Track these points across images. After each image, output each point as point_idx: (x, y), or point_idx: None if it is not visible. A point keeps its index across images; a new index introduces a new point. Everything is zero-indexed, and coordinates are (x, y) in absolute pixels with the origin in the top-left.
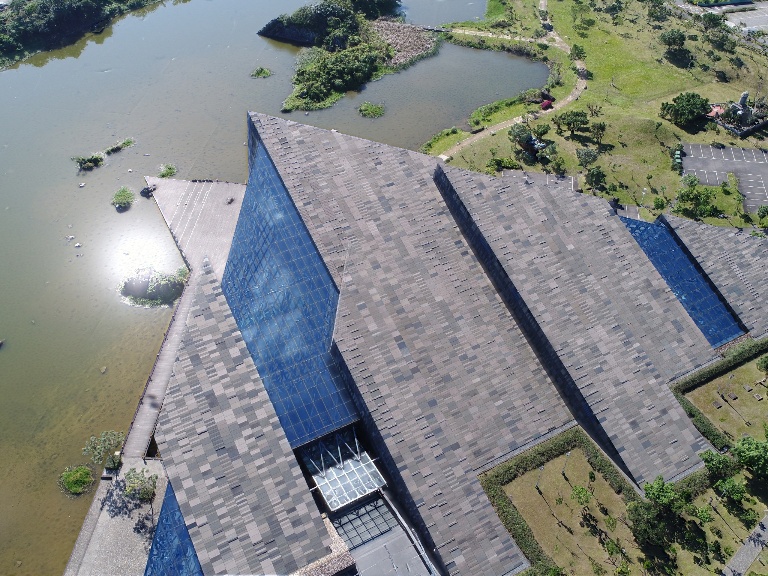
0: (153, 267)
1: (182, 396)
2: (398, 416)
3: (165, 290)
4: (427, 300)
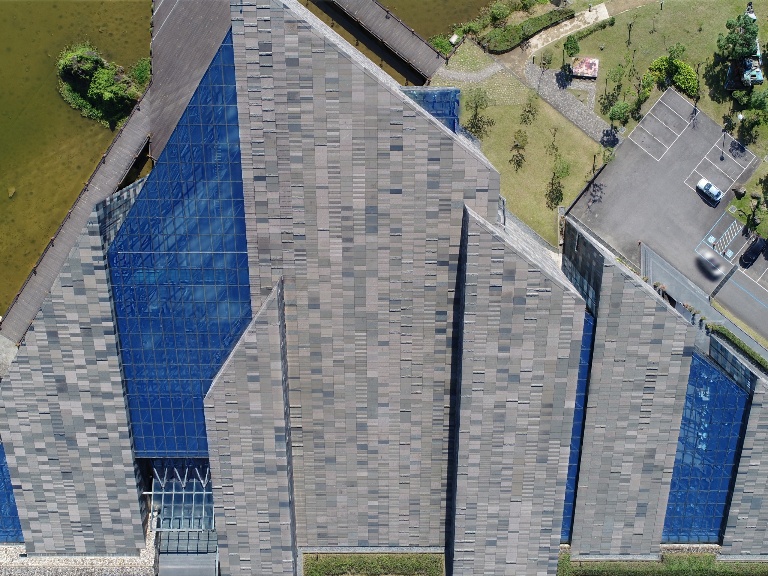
0: (101, 60)
1: (30, 370)
2: (240, 502)
3: (108, 104)
4: (356, 370)
